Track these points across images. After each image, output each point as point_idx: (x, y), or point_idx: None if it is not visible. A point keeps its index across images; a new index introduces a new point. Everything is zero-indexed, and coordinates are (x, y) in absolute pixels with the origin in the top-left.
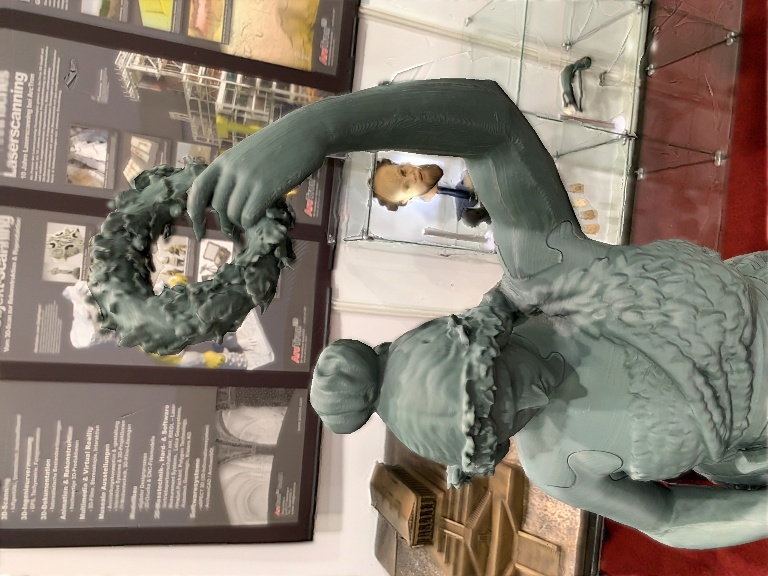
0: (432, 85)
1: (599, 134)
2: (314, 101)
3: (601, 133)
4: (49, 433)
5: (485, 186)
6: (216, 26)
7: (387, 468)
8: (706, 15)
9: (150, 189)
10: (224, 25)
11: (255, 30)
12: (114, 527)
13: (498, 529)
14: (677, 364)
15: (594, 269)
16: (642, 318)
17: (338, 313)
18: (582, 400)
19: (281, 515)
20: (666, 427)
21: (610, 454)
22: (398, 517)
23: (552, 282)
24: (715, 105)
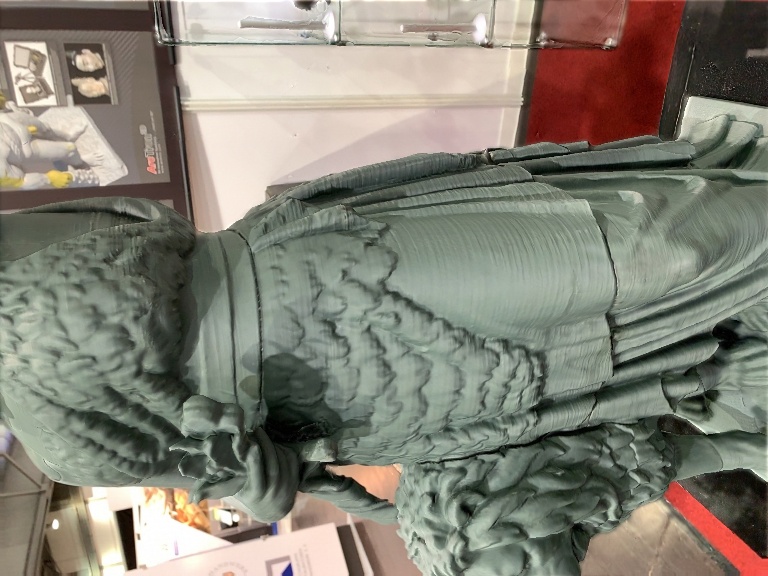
0: None
1: None
2: None
3: None
4: None
5: None
6: None
7: None
8: None
9: None
10: None
11: None
12: None
13: None
14: (43, 416)
15: None
16: (2, 363)
17: (194, 114)
18: (14, 421)
19: None
20: (76, 461)
21: None
22: None
23: None
24: None
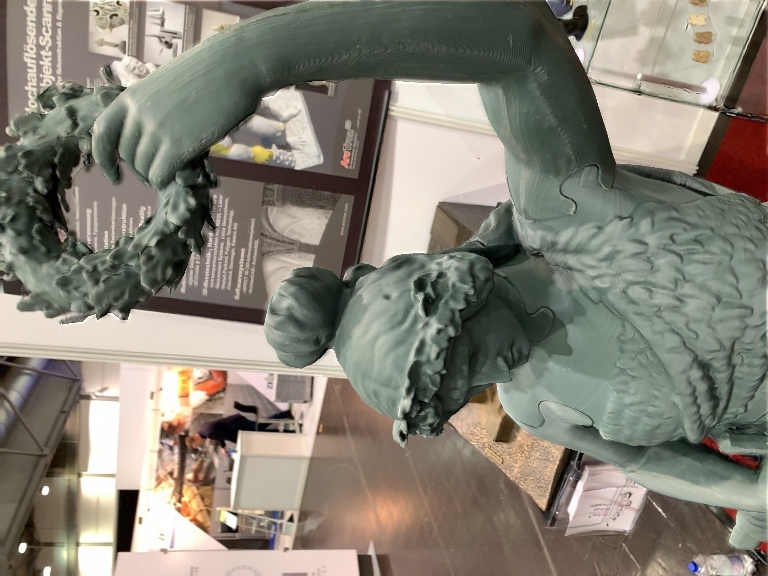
0: None
1: None
2: None
3: None
4: (105, 208)
5: (493, 115)
6: None
7: None
8: None
9: (53, 117)
10: None
11: None
12: (167, 297)
13: None
14: (674, 356)
15: (610, 229)
16: (650, 297)
17: (395, 119)
18: (565, 358)
19: None
20: (645, 408)
21: (582, 413)
22: None
23: (559, 232)
24: None
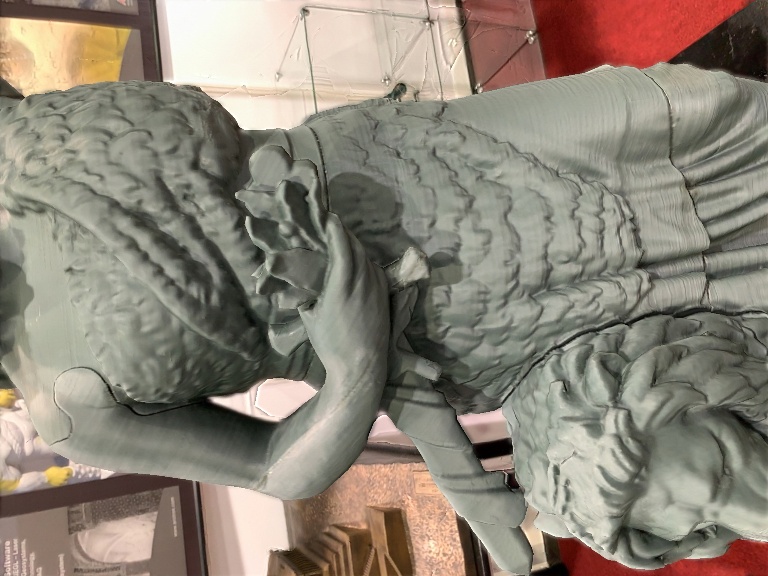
0: None
1: None
2: None
3: None
4: None
5: None
6: None
7: (279, 554)
8: (499, 21)
9: None
10: None
11: None
12: None
13: None
14: (83, 206)
15: None
16: (44, 164)
17: None
18: (32, 305)
19: None
20: (109, 302)
21: (81, 369)
22: None
23: None
24: None
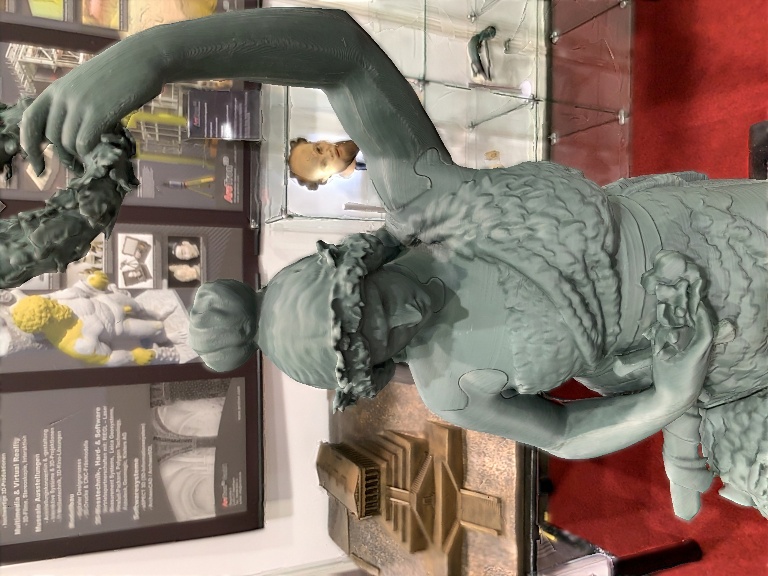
0: (273, 11)
1: (509, 101)
2: (223, 85)
3: (510, 100)
4: None
5: (347, 117)
6: (112, 13)
7: (331, 446)
8: None
9: None
10: (121, 11)
11: (154, 15)
12: (53, 539)
13: (441, 490)
14: (544, 274)
15: (462, 192)
16: (509, 234)
17: None
18: (465, 321)
19: (229, 506)
20: (541, 336)
21: (495, 370)
22: (345, 492)
23: (425, 209)
24: (617, 68)
